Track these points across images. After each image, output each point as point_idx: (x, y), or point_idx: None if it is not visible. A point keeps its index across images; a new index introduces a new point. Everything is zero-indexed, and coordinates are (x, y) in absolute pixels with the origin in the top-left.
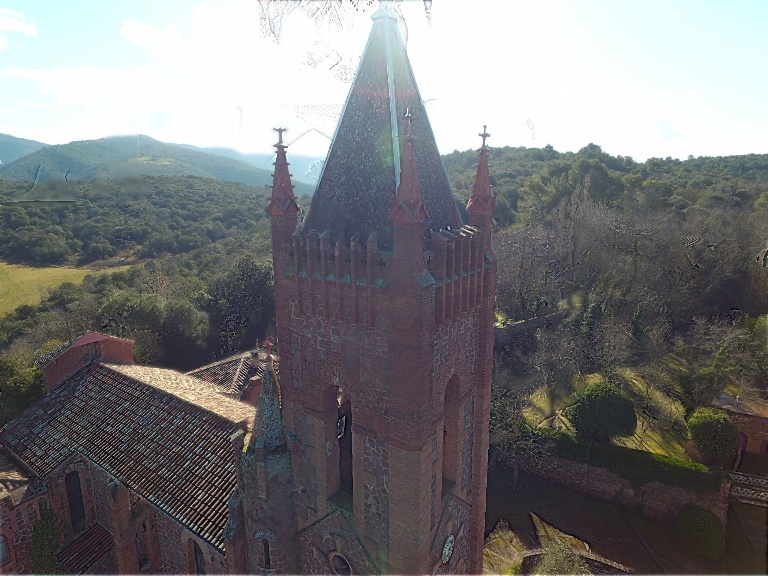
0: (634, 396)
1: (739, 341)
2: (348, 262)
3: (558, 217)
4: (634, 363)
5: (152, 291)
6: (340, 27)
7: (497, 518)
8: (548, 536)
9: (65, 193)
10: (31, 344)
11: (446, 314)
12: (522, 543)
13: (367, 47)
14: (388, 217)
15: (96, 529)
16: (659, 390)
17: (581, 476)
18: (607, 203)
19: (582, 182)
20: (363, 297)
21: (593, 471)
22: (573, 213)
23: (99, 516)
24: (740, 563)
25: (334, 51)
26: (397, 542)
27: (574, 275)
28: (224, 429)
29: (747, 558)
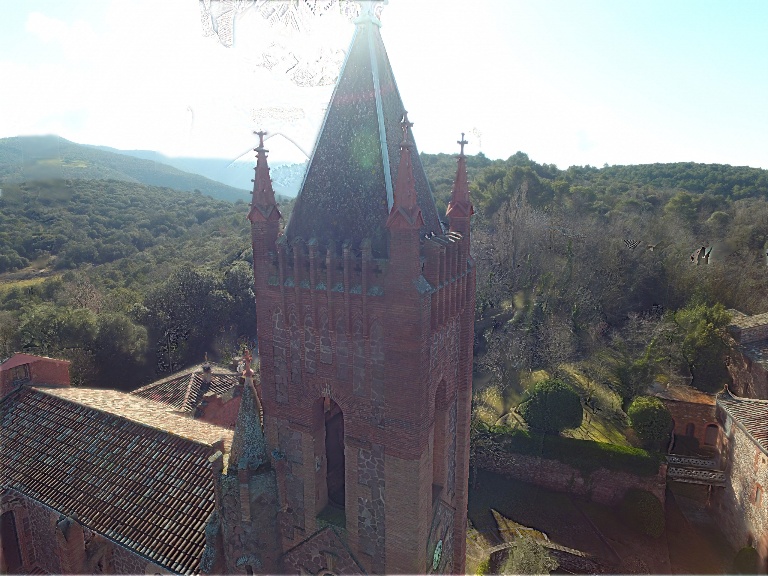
0: (576, 389)
1: (667, 334)
2: (340, 270)
3: (499, 222)
4: (577, 358)
5: (80, 305)
6: (297, 30)
7: None
8: (509, 530)
9: None
10: None
11: None
12: (486, 540)
13: (350, 51)
14: (379, 224)
15: (36, 574)
16: None
17: (535, 469)
18: (543, 208)
19: (520, 188)
20: (357, 305)
21: (546, 464)
22: (513, 218)
23: (39, 559)
24: (678, 537)
25: (291, 54)
26: (394, 554)
27: (516, 277)
28: (187, 451)
29: (683, 532)
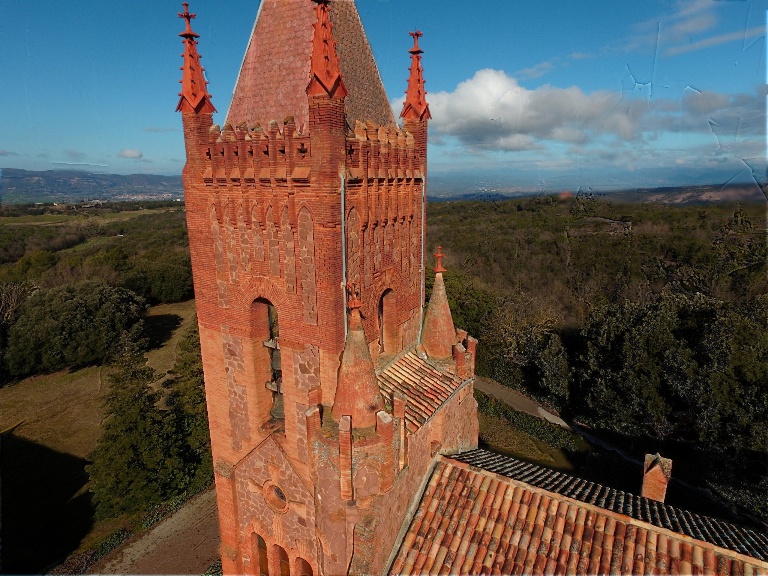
0: None
1: None
2: None
3: None
4: None
5: None
6: None
7: None
8: None
9: None
10: None
11: None
12: None
13: None
14: None
15: None
16: None
17: None
18: None
19: None
20: None
21: None
22: None
23: None
24: None
25: None
26: None
27: None
28: (609, 509)
29: None
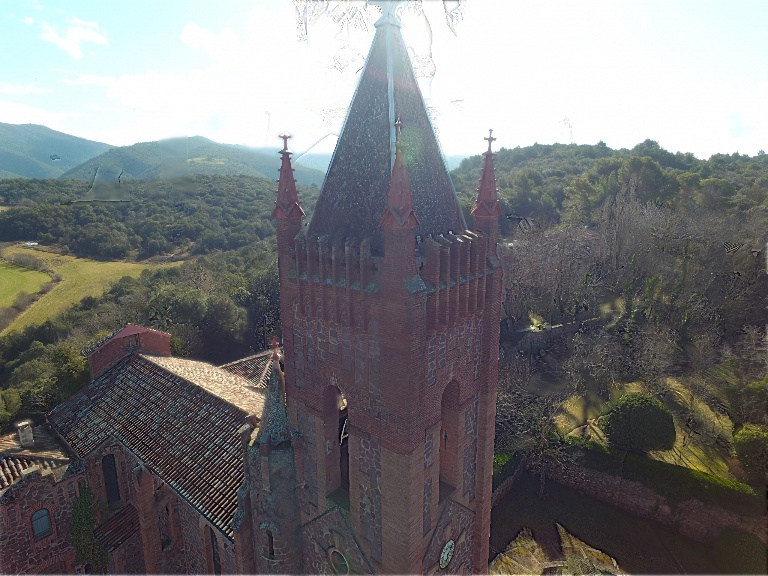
0: (678, 408)
1: None
2: (344, 266)
3: (602, 218)
4: (676, 373)
5: (196, 287)
6: (366, 31)
7: (520, 526)
8: (573, 548)
9: (120, 193)
10: (86, 334)
11: (441, 320)
12: (545, 554)
13: (370, 54)
14: None
15: (129, 509)
16: (702, 403)
17: (613, 489)
18: (656, 203)
19: (629, 181)
20: (357, 301)
21: (626, 484)
22: (618, 214)
23: (132, 497)
24: None
25: (360, 55)
26: (389, 543)
27: (617, 279)
28: (243, 422)
29: None
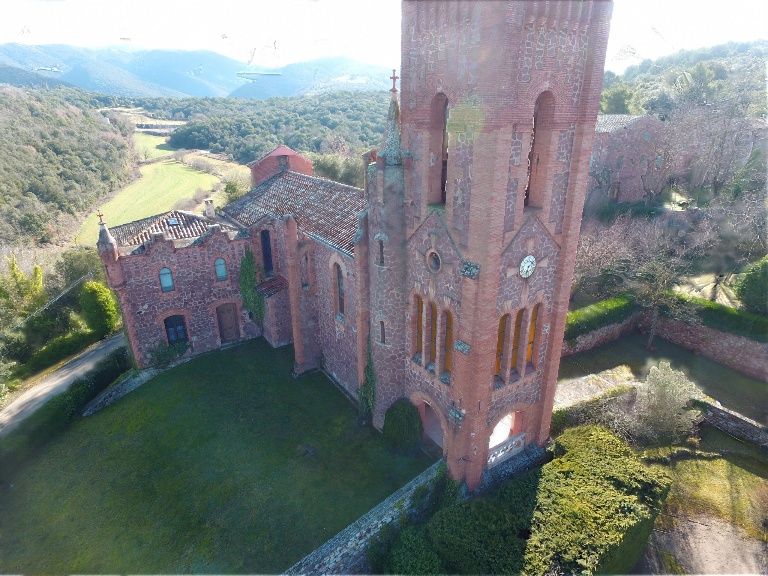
0: None
1: None
2: None
3: None
4: None
5: None
6: None
7: (620, 362)
8: None
9: (275, 67)
10: None
11: (541, 12)
12: None
13: None
14: None
15: (279, 277)
16: None
17: (735, 351)
18: None
19: None
20: None
21: (752, 346)
22: None
23: (281, 270)
24: None
25: None
26: (474, 223)
27: None
28: None
29: None
